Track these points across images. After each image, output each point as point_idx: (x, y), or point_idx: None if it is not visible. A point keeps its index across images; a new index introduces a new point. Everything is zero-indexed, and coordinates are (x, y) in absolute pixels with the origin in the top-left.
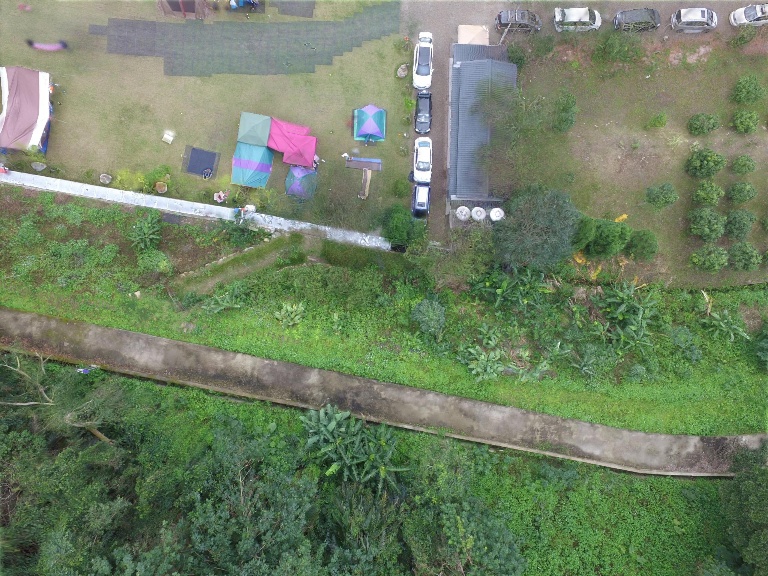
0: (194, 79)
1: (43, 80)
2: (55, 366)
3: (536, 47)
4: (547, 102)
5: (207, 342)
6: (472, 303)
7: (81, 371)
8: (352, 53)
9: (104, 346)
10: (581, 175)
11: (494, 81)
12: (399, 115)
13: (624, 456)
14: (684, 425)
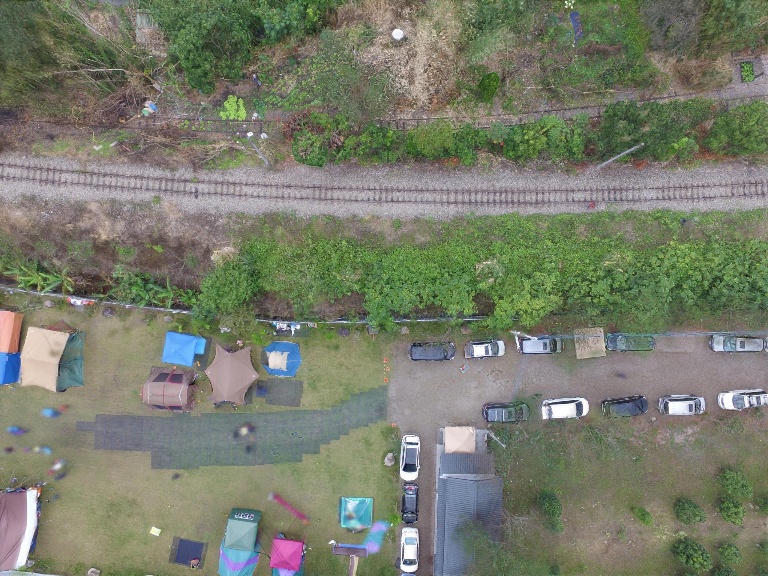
0: (182, 472)
1: (31, 496)
2: None
3: None
4: (534, 484)
5: None
6: None
7: None
8: (339, 441)
9: None
10: (568, 556)
11: (480, 502)
12: (386, 501)
13: None
14: None
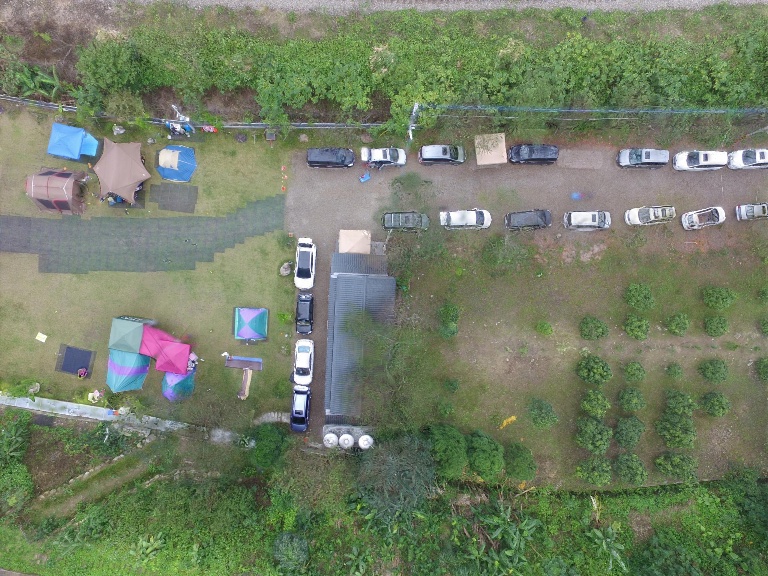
0: (70, 276)
1: None
2: None
3: (425, 244)
4: (435, 300)
5: (60, 575)
6: (348, 516)
7: None
8: (234, 250)
9: None
10: (469, 375)
11: (369, 298)
12: (282, 313)
13: None
14: None
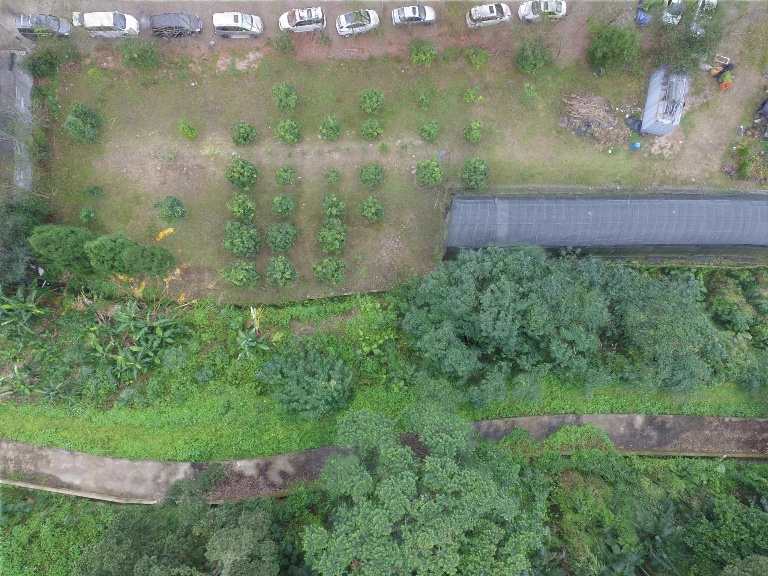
0: None
1: None
2: None
3: (72, 53)
4: None
5: None
6: None
7: None
8: None
9: None
10: (122, 187)
11: None
12: None
13: (107, 485)
14: (175, 451)
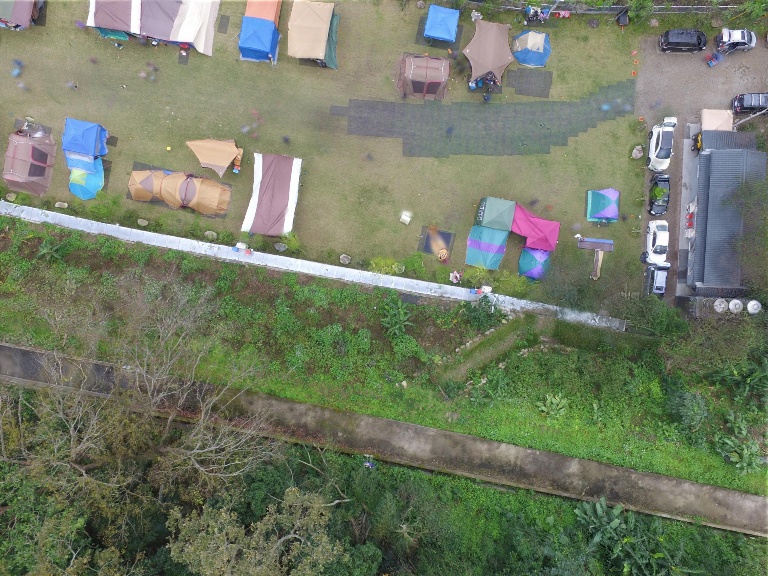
0: (432, 160)
1: (296, 166)
2: (331, 456)
3: None
4: None
5: (472, 432)
6: (709, 387)
7: (369, 466)
8: (587, 134)
9: (375, 436)
10: None
11: (748, 171)
12: (632, 196)
13: None
14: None
